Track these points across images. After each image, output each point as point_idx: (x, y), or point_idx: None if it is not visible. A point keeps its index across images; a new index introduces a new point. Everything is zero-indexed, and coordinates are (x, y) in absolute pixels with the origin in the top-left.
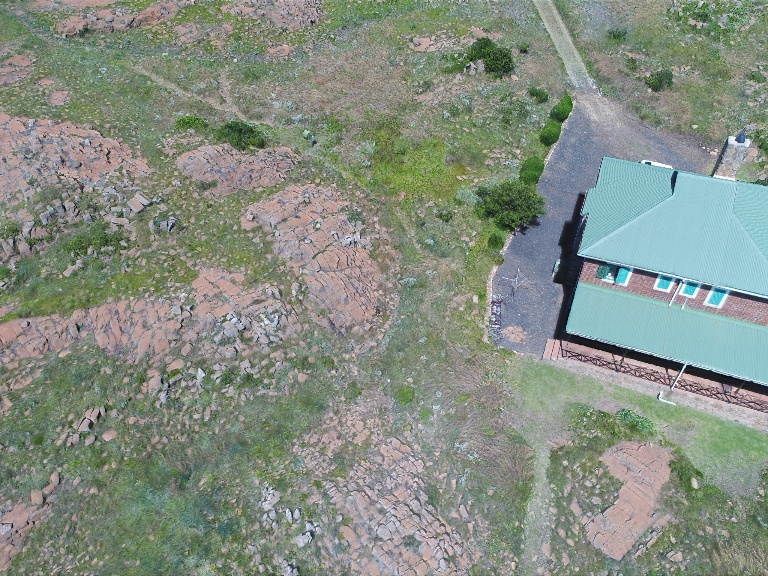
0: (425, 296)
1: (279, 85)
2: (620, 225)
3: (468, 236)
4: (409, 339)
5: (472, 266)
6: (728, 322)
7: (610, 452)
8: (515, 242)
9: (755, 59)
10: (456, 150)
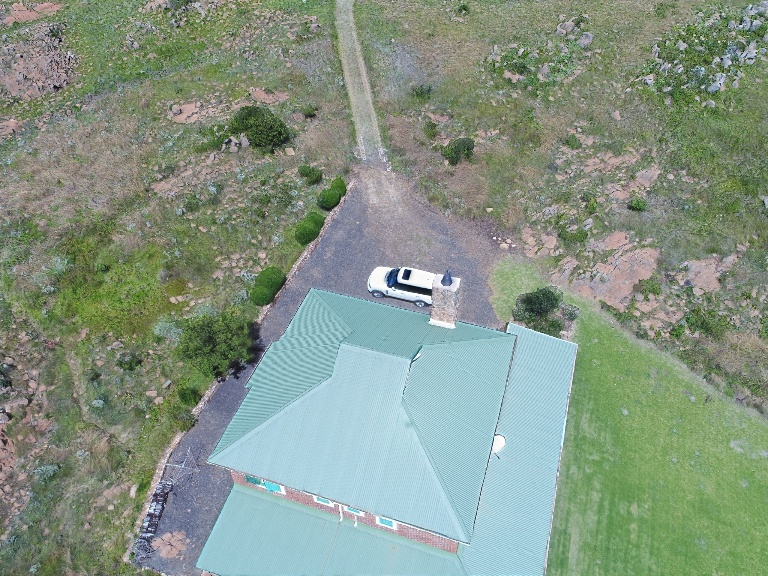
0: (67, 490)
1: None
2: (263, 420)
3: (156, 389)
4: (16, 568)
5: (147, 436)
6: (409, 547)
7: None
8: (222, 391)
9: (574, 118)
10: (176, 261)
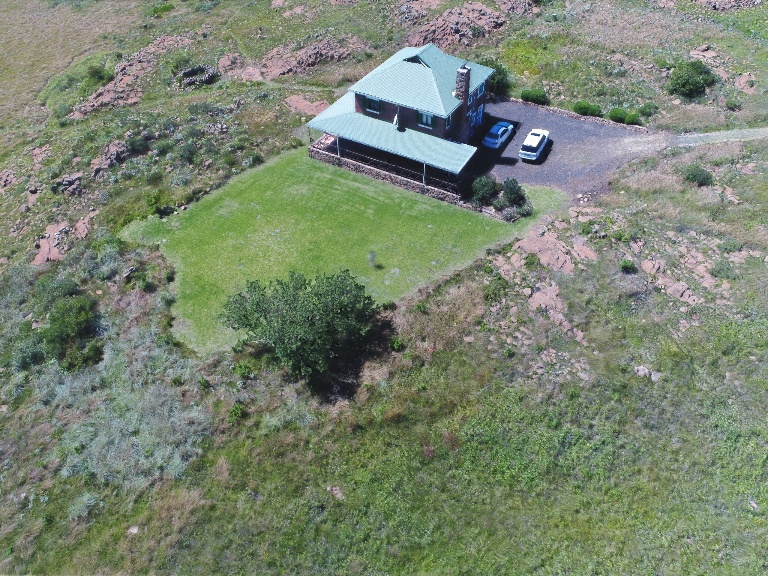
0: None
1: (614, 6)
2: None
3: None
4: None
5: None
6: None
7: (327, 102)
8: None
9: None
10: (551, 66)
